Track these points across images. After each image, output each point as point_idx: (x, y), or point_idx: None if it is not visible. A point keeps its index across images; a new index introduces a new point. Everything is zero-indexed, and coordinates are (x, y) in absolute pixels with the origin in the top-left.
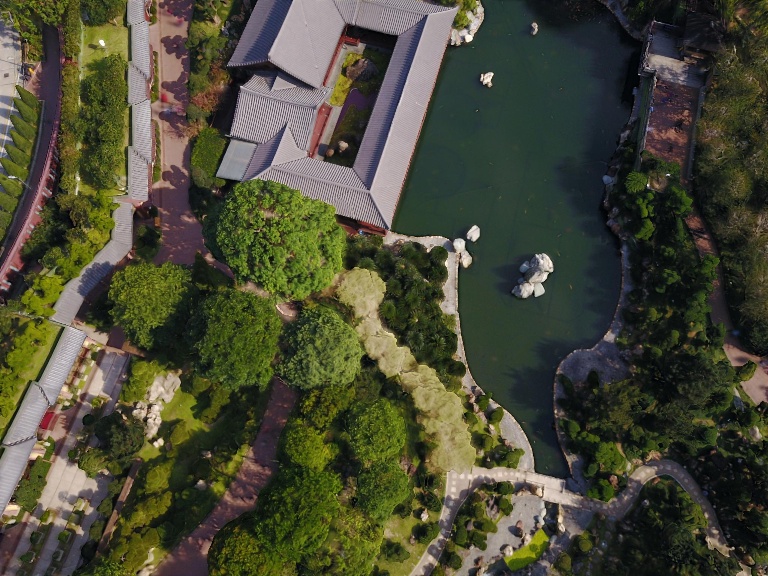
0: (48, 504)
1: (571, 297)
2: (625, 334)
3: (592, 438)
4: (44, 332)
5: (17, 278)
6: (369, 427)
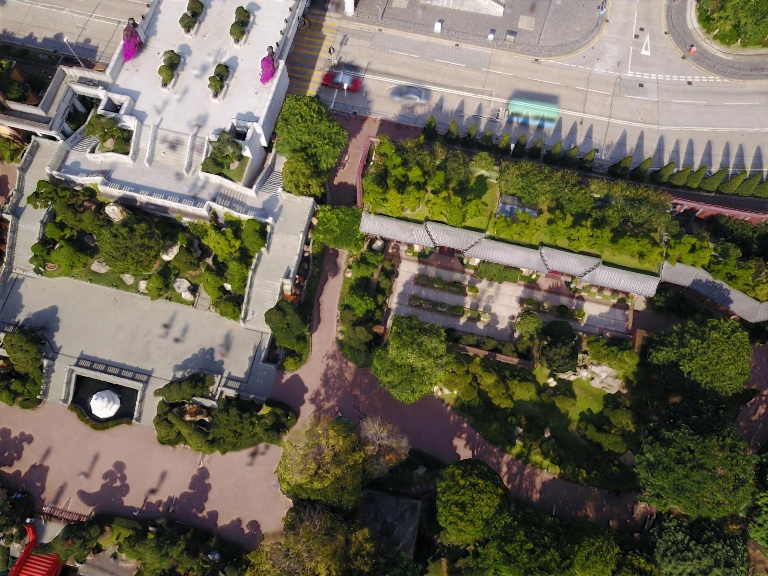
0: (482, 288)
1: None
2: None
3: None
4: (653, 261)
5: (688, 215)
6: None
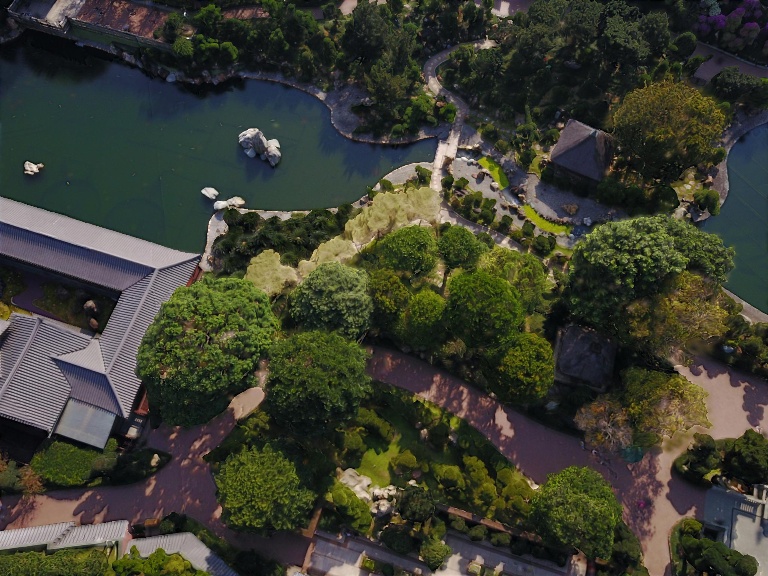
0: None
1: (282, 121)
2: (320, 84)
3: (409, 111)
4: None
5: None
6: (412, 245)
